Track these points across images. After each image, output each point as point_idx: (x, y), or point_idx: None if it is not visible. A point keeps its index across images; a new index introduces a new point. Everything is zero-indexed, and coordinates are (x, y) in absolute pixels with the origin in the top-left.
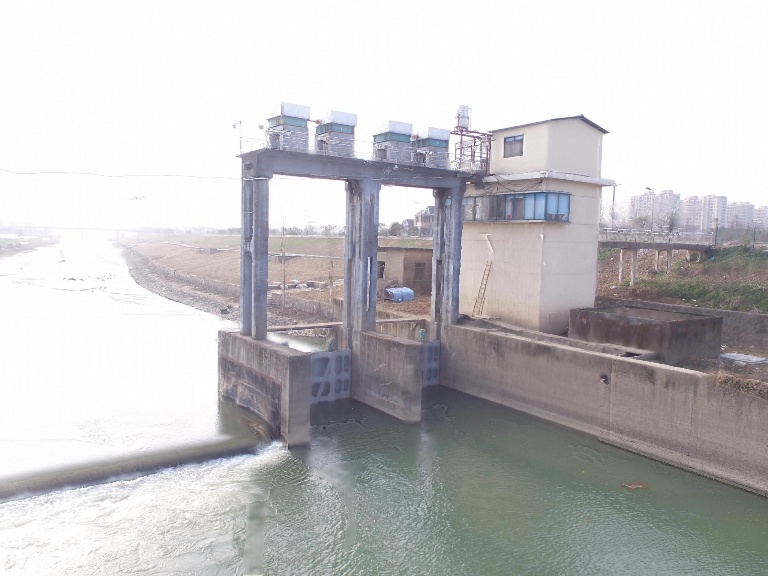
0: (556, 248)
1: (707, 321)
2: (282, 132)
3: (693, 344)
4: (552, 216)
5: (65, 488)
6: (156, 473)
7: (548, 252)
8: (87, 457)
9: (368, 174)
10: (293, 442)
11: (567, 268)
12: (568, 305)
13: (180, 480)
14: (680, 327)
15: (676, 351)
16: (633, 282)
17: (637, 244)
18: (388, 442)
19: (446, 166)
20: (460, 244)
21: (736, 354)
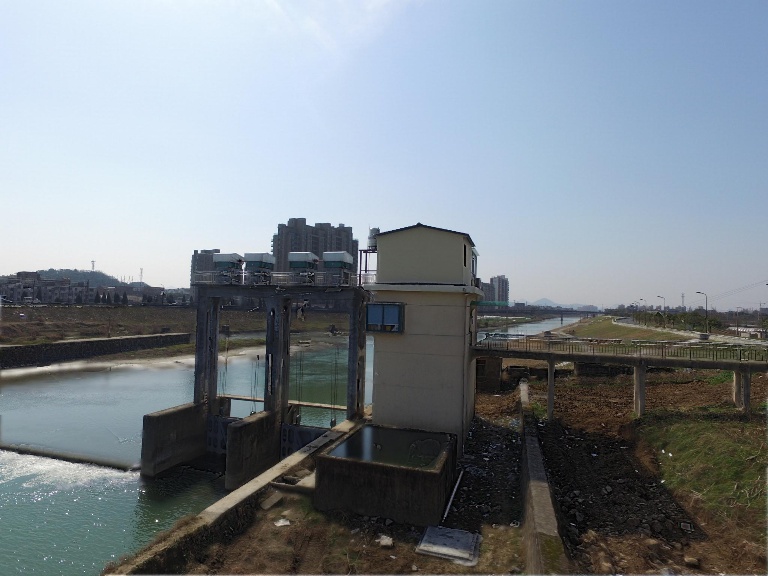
0: (393, 359)
1: (396, 471)
2: (203, 273)
3: (366, 494)
4: (378, 327)
5: (51, 457)
6: (82, 463)
7: (382, 362)
8: (95, 447)
9: (270, 294)
10: (143, 471)
11: (410, 381)
12: (415, 421)
13: (78, 470)
14: (337, 466)
15: (331, 494)
16: (639, 412)
17: (643, 360)
18: (191, 494)
19: (327, 283)
20: (355, 348)
21: (461, 535)
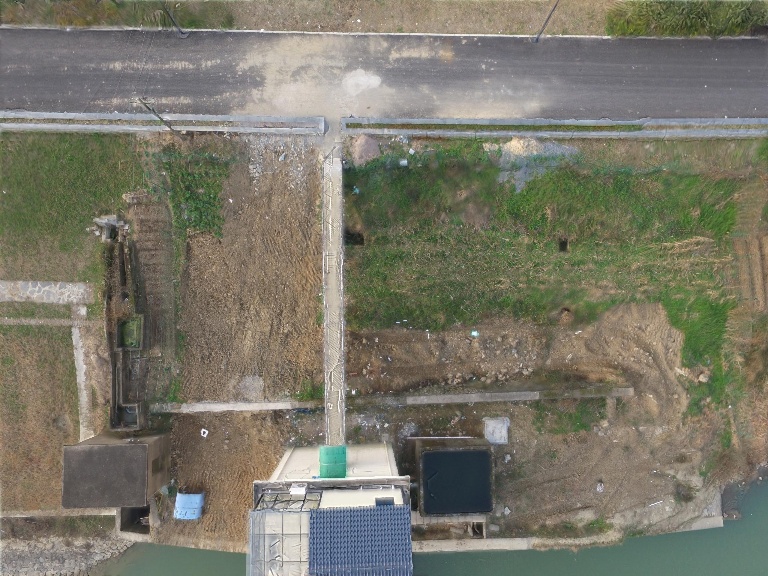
0: None
1: None
2: None
3: None
4: None
5: None
6: None
7: None
8: None
9: None
10: None
11: None
12: None
13: None
14: None
15: None
16: None
17: None
18: None
19: None
20: None
21: (490, 426)
